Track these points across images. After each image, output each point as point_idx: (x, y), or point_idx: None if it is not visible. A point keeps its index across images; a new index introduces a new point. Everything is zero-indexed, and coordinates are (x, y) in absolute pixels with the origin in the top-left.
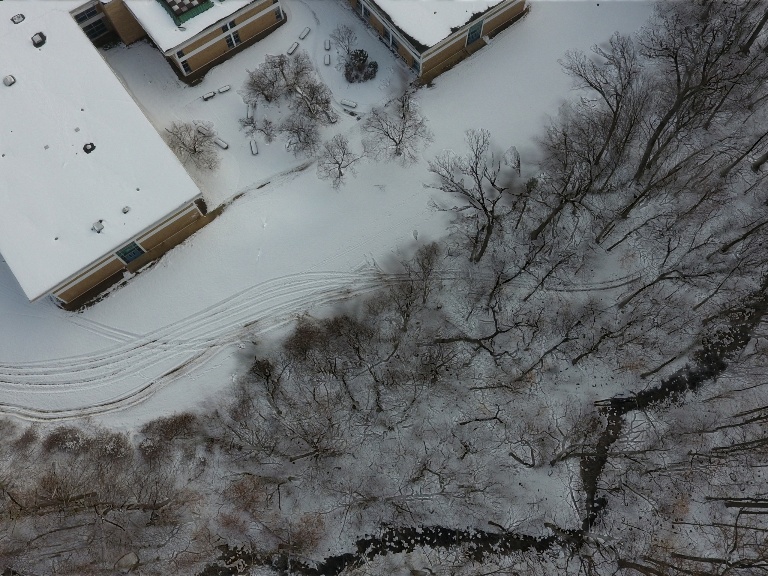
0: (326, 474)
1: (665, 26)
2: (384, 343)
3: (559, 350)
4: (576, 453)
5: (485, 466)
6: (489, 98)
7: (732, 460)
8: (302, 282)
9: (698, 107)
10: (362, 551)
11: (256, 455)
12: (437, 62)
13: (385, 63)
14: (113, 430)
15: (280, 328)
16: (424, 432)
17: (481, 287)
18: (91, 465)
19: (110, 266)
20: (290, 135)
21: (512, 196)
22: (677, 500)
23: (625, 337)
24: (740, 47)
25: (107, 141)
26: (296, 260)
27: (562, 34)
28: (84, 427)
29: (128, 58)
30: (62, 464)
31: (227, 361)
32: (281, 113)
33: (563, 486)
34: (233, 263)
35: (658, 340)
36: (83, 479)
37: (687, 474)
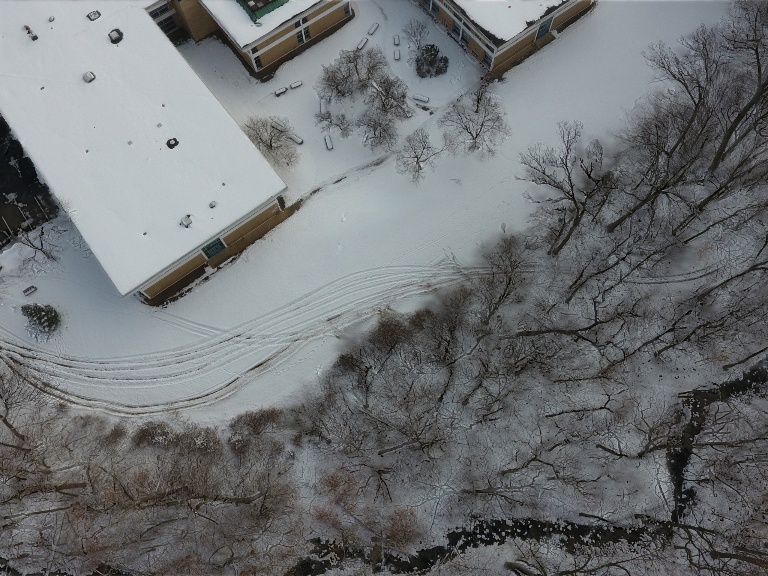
0: (415, 467)
1: (746, 18)
2: (467, 336)
3: (661, 340)
4: (662, 445)
5: (574, 458)
6: (560, 92)
7: None
8: (383, 276)
9: None
10: (453, 544)
11: (344, 449)
12: (507, 56)
13: (455, 58)
14: (201, 425)
15: (362, 322)
16: (511, 425)
17: (561, 280)
18: (181, 459)
19: (193, 261)
20: (367, 130)
21: (587, 189)
22: (766, 491)
23: (706, 329)
24: None
25: (190, 136)
26: (376, 254)
27: (630, 28)
28: (172, 422)
29: (198, 54)
30: (152, 459)
31: (311, 355)
32: (353, 108)
33: (651, 478)
34: (314, 257)
35: (738, 332)
36: (174, 473)
37: None
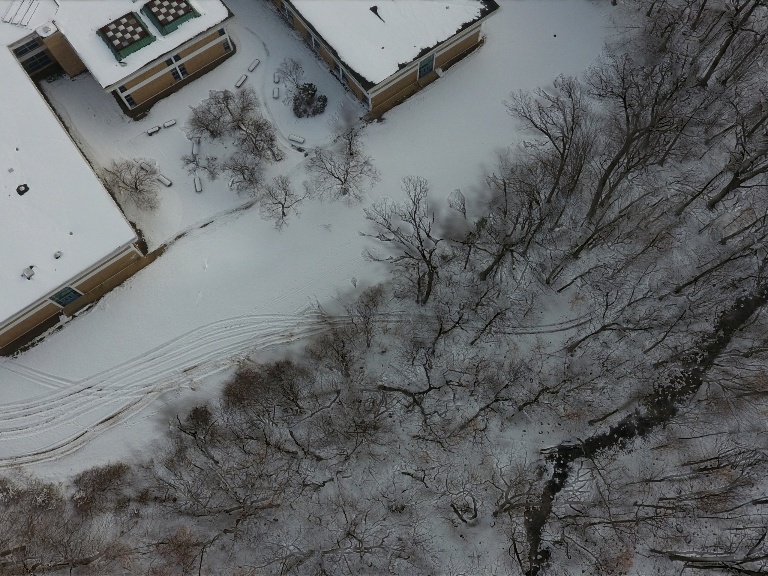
0: (263, 526)
1: (613, 66)
2: (326, 389)
3: (492, 409)
4: (520, 503)
5: (425, 518)
6: (440, 133)
7: (679, 511)
8: (243, 325)
9: (653, 143)
10: None
11: (191, 506)
12: (388, 96)
13: (335, 97)
14: (45, 480)
15: (220, 373)
16: (364, 482)
17: (427, 330)
18: (21, 517)
19: (44, 310)
20: (233, 174)
21: (461, 235)
22: (621, 553)
23: (573, 382)
24: (698, 80)
25: (41, 182)
26: (238, 303)
27: (517, 66)
28: (15, 477)
29: (72, 91)
30: None
31: (164, 408)
32: (227, 149)
33: (506, 538)
34: (173, 306)
35: (607, 385)
36: (12, 533)
37: (632, 526)
